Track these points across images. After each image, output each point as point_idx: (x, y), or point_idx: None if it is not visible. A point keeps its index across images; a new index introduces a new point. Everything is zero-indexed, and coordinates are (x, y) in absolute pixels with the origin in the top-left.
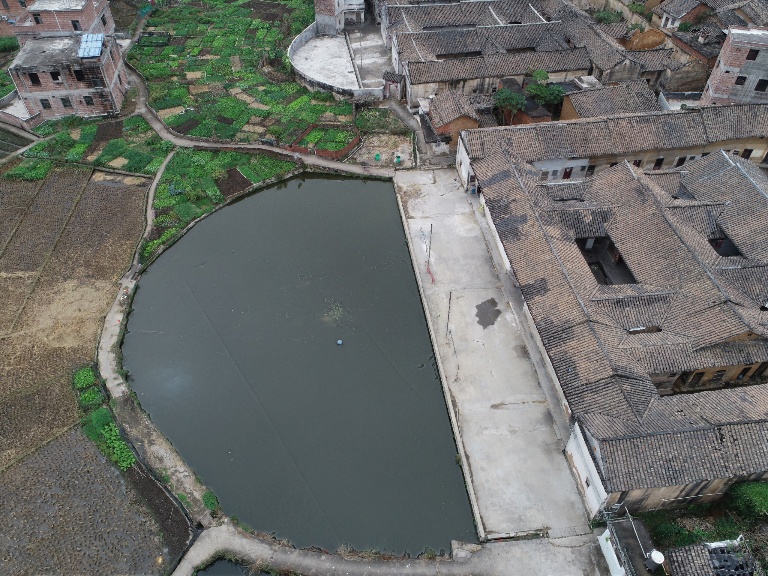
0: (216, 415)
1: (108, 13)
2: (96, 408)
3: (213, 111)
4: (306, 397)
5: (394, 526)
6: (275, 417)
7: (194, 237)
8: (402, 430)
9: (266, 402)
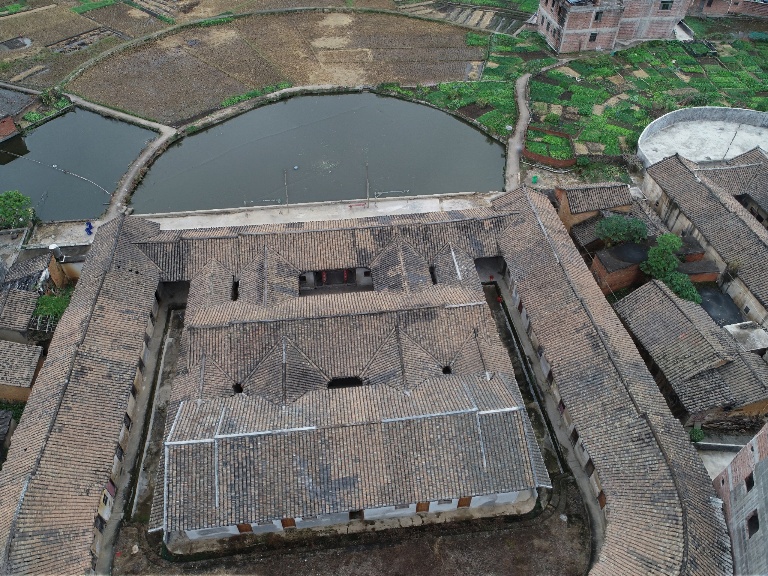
0: (250, 129)
1: (683, 4)
2: (263, 92)
3: (531, 66)
4: (253, 157)
5: (159, 196)
6: (242, 147)
7: (414, 108)
8: (216, 193)
9: (253, 143)
